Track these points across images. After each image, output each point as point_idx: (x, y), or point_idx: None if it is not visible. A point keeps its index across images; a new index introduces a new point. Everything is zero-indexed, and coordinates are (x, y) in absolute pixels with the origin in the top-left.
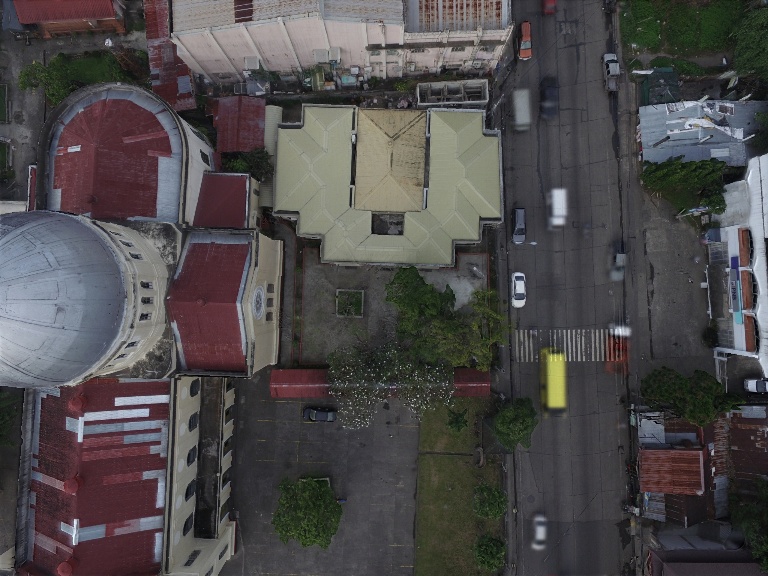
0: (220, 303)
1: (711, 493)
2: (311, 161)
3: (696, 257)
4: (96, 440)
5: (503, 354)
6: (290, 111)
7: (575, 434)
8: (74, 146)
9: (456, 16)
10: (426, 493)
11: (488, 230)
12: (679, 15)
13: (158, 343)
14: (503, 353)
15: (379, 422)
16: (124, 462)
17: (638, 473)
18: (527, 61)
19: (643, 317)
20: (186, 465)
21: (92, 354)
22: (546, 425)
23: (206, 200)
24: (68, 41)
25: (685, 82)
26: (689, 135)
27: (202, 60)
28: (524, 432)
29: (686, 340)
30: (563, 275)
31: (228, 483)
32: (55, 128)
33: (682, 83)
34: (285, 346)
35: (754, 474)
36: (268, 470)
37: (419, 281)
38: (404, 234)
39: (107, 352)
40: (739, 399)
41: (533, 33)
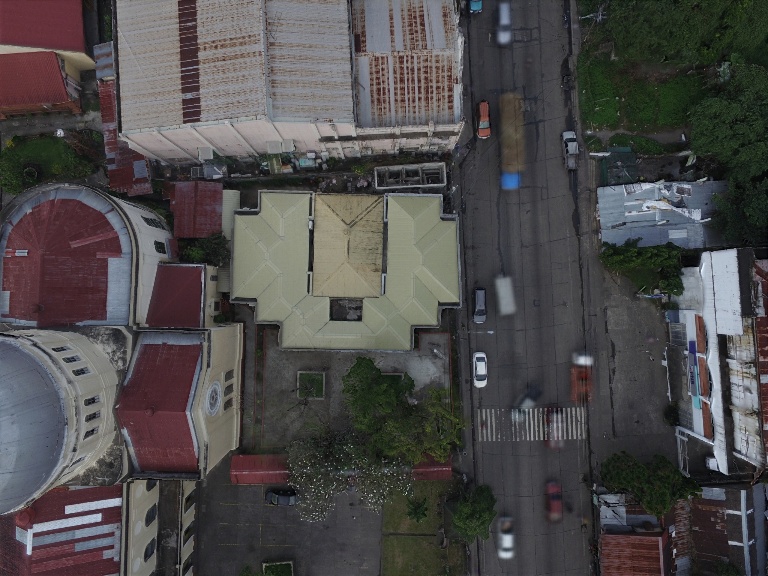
0: (169, 412)
1: (672, 575)
2: (267, 250)
3: (657, 334)
4: (46, 551)
5: (465, 434)
6: (249, 191)
7: (538, 513)
8: (21, 250)
9: (408, 109)
10: (390, 575)
11: (449, 309)
12: (637, 92)
13: (108, 450)
14: (465, 433)
15: (342, 504)
16: (76, 570)
17: (599, 557)
18: (486, 139)
19: (605, 395)
20: (143, 562)
21: (30, 487)
22: (509, 505)
23: (160, 293)
24: (24, 122)
25: (644, 159)
26: (647, 217)
27: (155, 150)
28: (481, 527)
29: (648, 418)
30: (525, 354)
31: (190, 569)
32: (4, 228)
33: (641, 160)
34: (247, 429)
35: (715, 555)
36: (231, 554)
37: (375, 374)
38: (362, 320)
39: (48, 480)
40: (697, 487)
41: (492, 111)
